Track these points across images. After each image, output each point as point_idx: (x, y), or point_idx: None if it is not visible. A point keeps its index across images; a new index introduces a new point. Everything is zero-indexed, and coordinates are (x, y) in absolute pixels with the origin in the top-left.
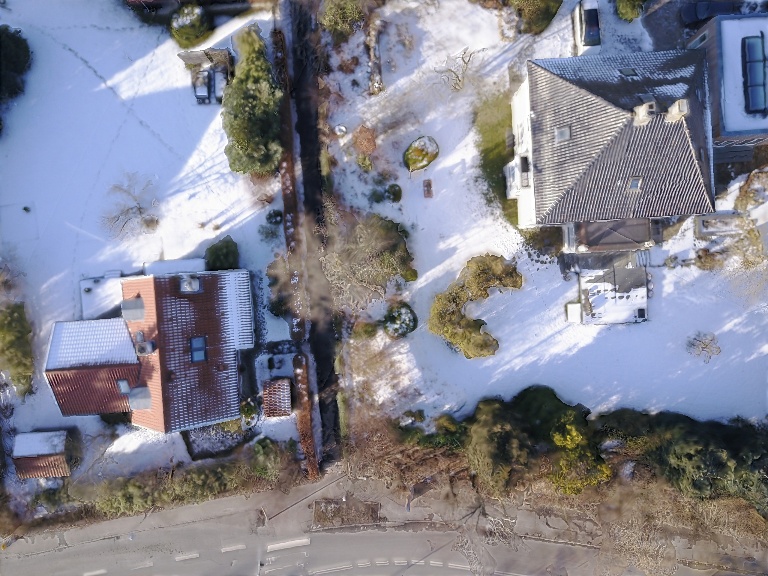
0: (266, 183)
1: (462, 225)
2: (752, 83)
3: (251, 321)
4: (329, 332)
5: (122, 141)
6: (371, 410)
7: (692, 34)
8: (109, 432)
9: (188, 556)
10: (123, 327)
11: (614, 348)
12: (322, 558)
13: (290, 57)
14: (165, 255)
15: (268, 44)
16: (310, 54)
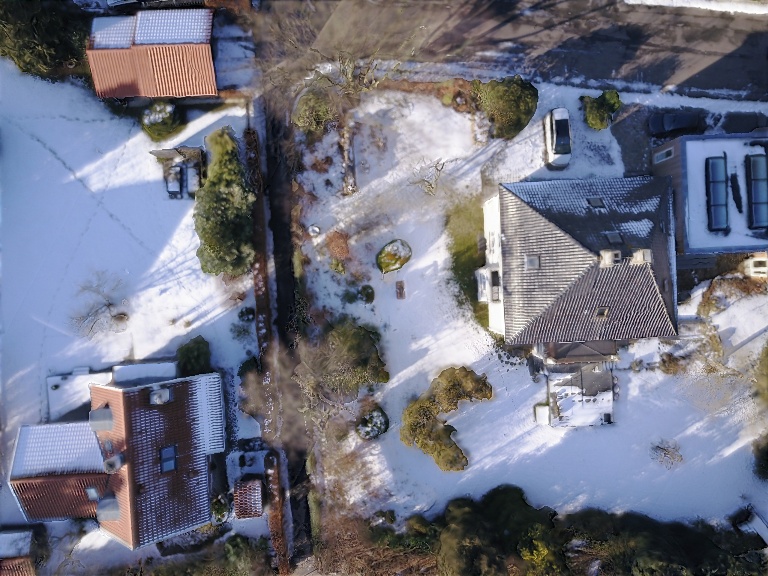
0: (238, 281)
1: (434, 327)
2: (715, 202)
3: (222, 425)
4: (301, 429)
5: (92, 235)
6: (342, 510)
7: (659, 143)
8: (76, 529)
9: None
10: (91, 433)
11: (581, 448)
12: None
13: (264, 154)
14: (135, 351)
15: (242, 144)
16: (284, 152)
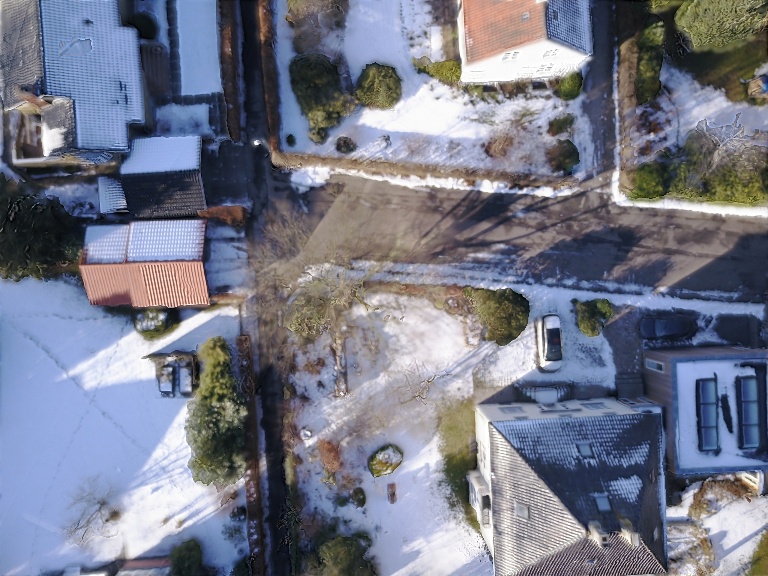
0: None
1: (425, 529)
2: (705, 424)
3: None
4: None
5: (83, 433)
6: None
7: (650, 345)
8: None
9: None
10: None
11: None
12: None
13: (256, 354)
14: (126, 551)
15: (234, 351)
16: (276, 352)
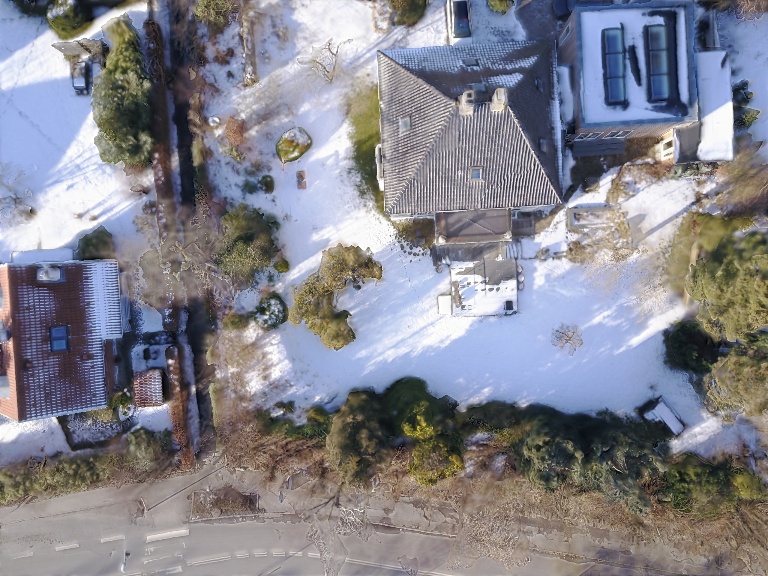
0: (142, 174)
1: (335, 217)
2: (611, 75)
3: (120, 311)
4: (206, 323)
5: (1, 131)
6: (243, 401)
7: None
8: None
9: (68, 546)
10: None
11: (486, 340)
12: (201, 549)
13: (167, 48)
14: (43, 245)
15: (141, 35)
16: (187, 45)
